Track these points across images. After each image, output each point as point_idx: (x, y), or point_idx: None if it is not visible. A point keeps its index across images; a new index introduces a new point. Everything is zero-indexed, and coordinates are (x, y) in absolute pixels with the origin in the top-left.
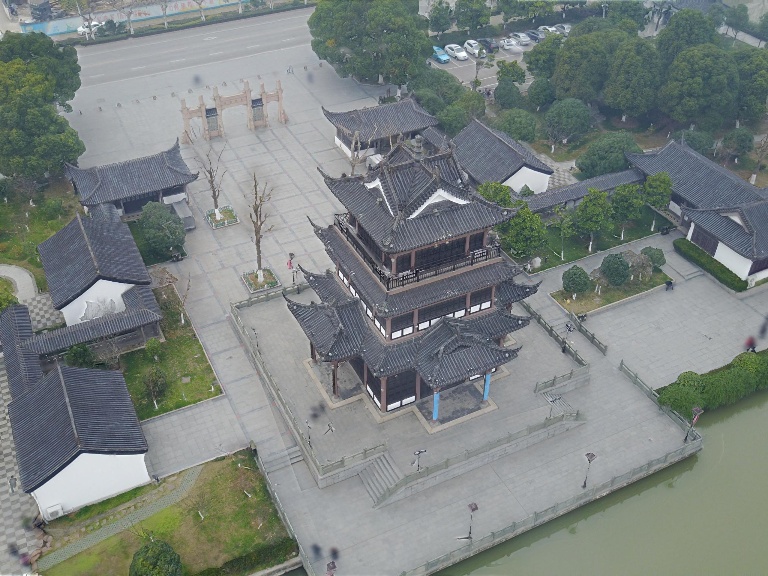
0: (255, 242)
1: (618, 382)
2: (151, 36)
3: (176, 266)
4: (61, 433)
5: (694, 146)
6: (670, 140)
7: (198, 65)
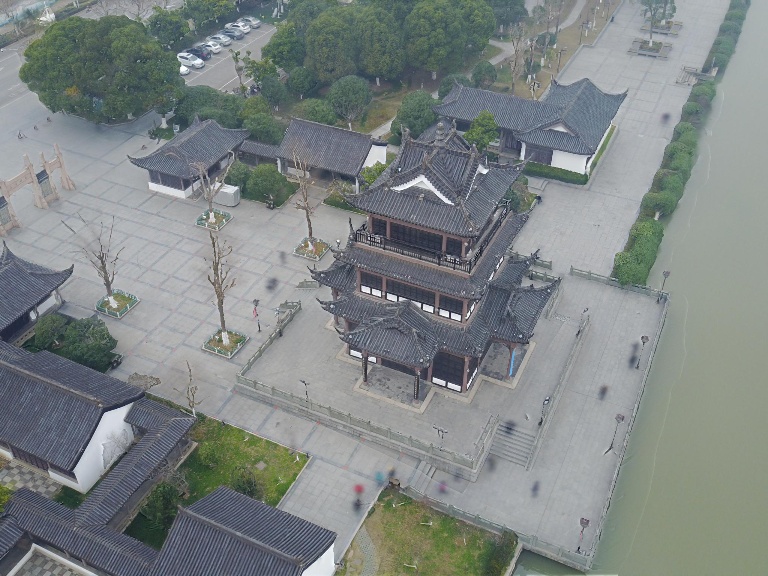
0: (217, 304)
1: (579, 284)
2: None
3: (121, 371)
4: (259, 569)
5: (466, 86)
6: (461, 85)
7: None
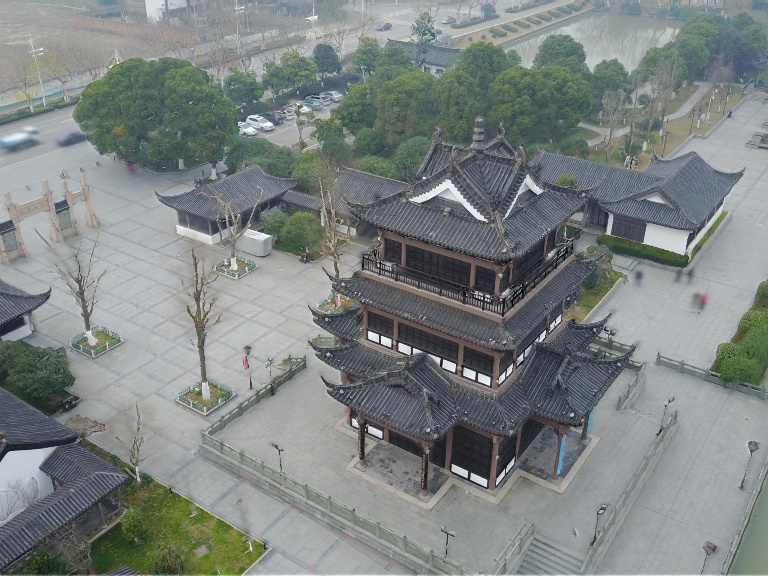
0: (197, 345)
1: (667, 376)
2: None
3: None
4: None
5: None
6: (542, 150)
7: None
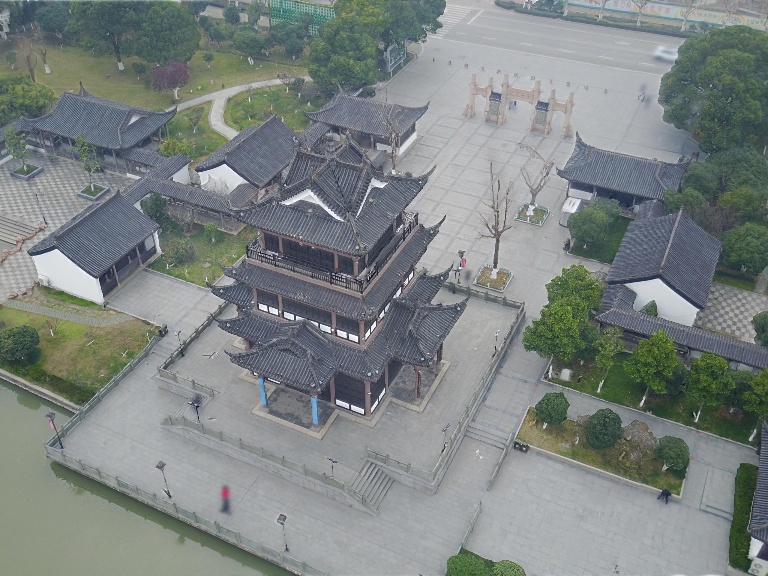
0: None
1: (457, 517)
2: (577, 23)
3: None
4: None
5: None
6: None
7: (575, 60)
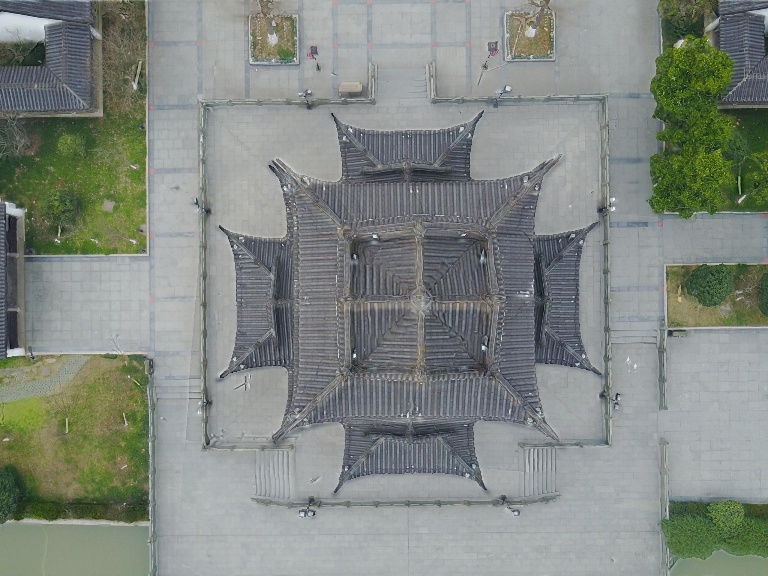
0: None
1: (642, 460)
2: None
3: None
4: None
5: None
6: None
7: None
